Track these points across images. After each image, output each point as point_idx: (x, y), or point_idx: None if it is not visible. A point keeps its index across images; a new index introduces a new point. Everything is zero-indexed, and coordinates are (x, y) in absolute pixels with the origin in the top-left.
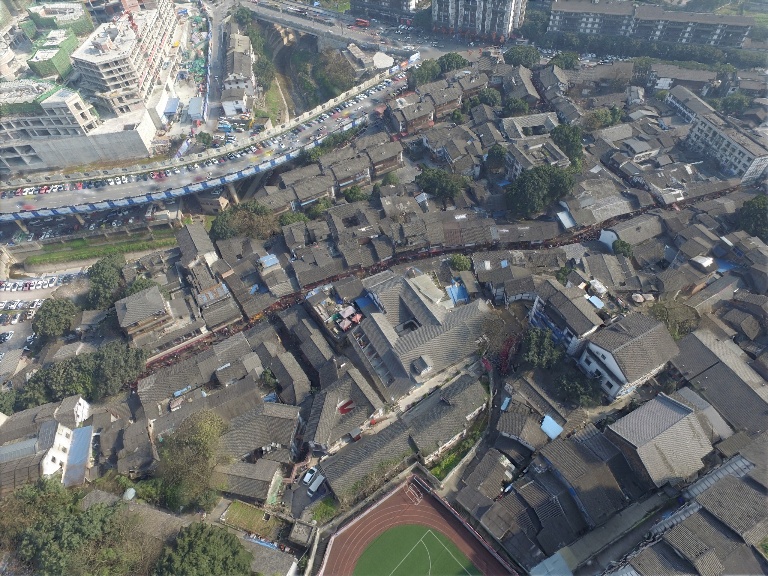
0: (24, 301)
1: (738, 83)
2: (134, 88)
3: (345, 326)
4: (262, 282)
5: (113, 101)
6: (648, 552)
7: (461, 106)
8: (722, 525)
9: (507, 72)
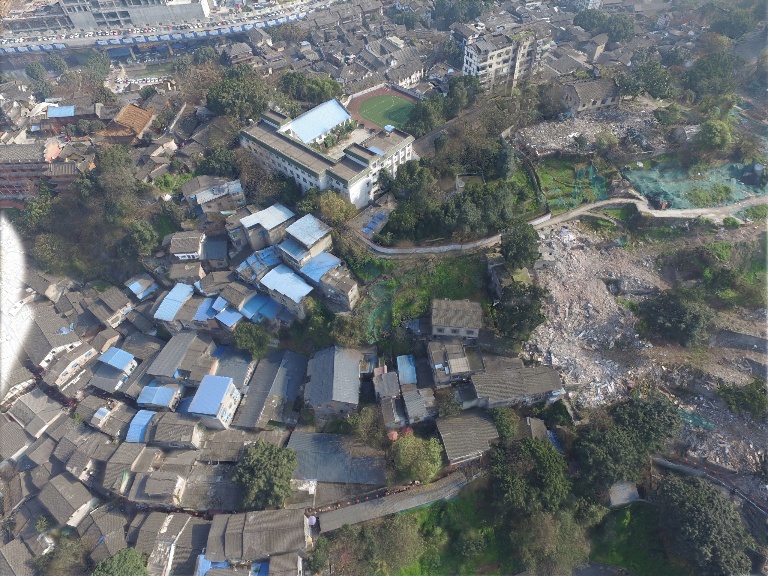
0: None
1: None
2: None
3: (351, 61)
4: (300, 58)
5: None
6: None
7: None
8: None
9: None
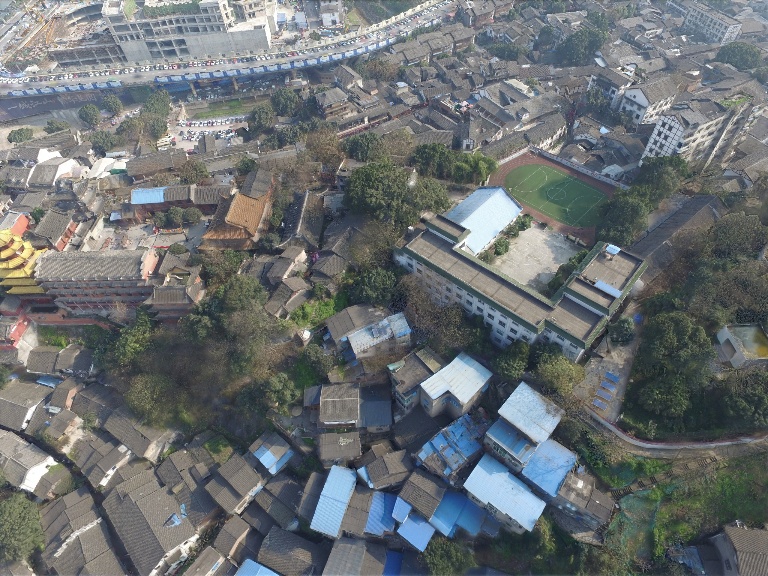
0: (212, 131)
1: None
2: None
3: (464, 109)
4: (395, 101)
5: (245, 7)
6: None
7: None
8: None
9: None
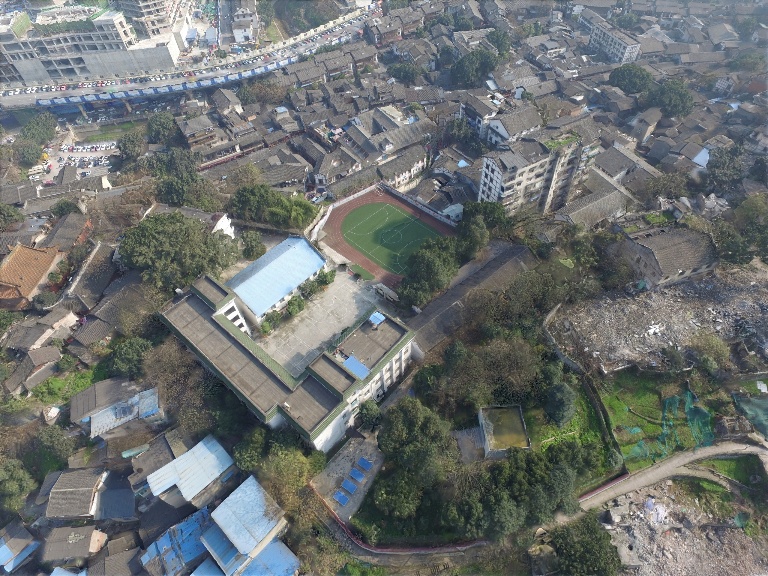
0: (94, 157)
1: (631, 6)
2: (164, 15)
3: (336, 138)
4: (276, 127)
5: (147, 24)
6: (491, 152)
7: (423, 27)
8: (528, 140)
9: (460, 3)
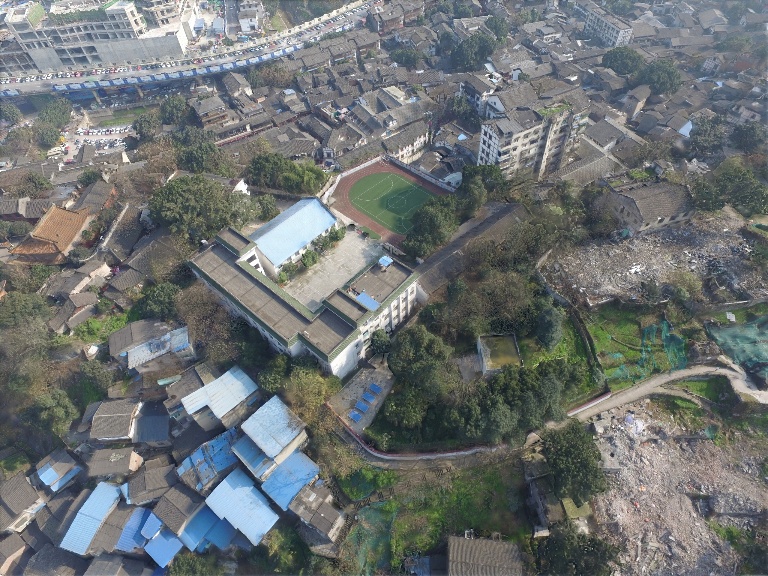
0: (109, 139)
1: None
2: (172, 4)
3: (342, 117)
4: (284, 108)
5: (157, 14)
6: None
7: (424, 15)
8: (523, 109)
9: None
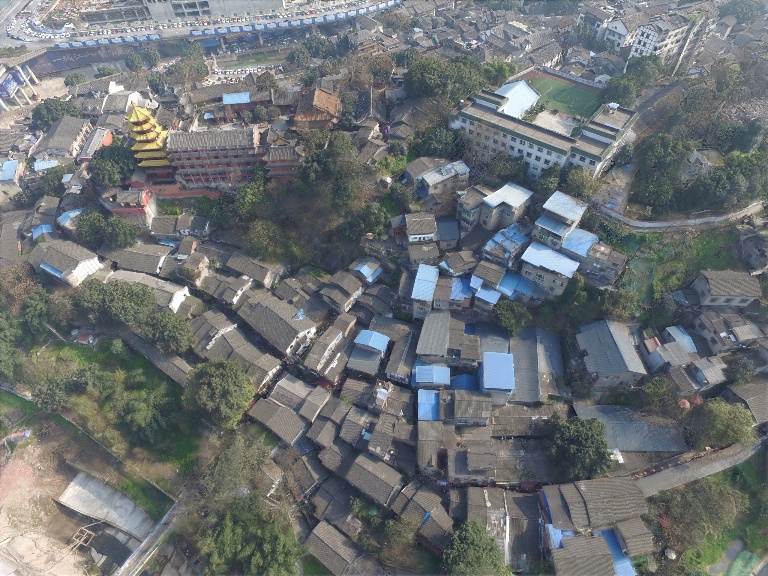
0: None
1: None
2: None
3: (475, 46)
4: (411, 45)
5: None
6: None
7: None
8: None
9: None
